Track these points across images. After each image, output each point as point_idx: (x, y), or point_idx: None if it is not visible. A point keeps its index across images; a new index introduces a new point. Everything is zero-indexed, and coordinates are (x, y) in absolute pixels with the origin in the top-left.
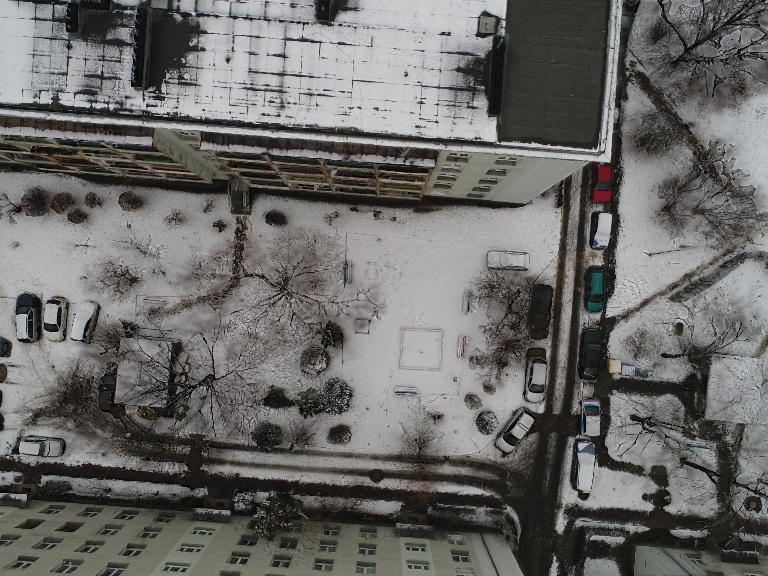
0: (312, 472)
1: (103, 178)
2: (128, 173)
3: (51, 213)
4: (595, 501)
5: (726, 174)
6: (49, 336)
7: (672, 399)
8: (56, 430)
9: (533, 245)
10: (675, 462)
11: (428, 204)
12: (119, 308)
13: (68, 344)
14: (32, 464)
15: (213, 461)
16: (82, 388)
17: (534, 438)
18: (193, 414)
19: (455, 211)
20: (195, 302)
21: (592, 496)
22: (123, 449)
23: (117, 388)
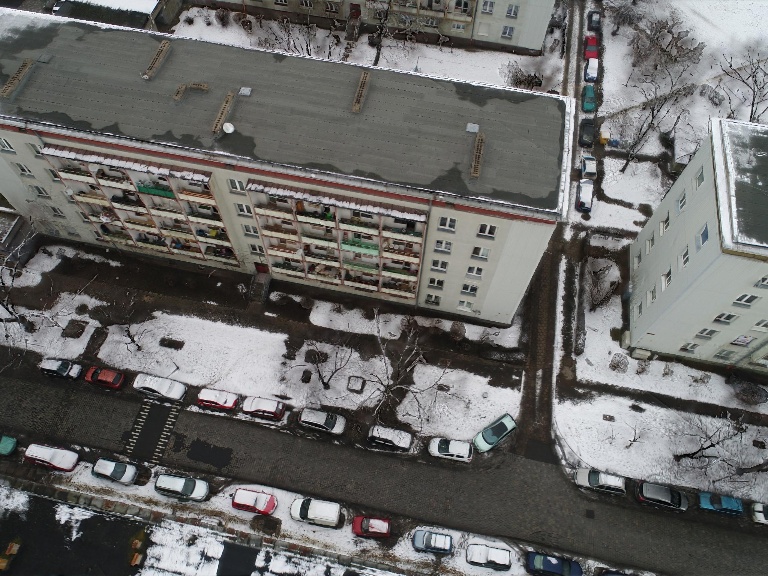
0: None
1: (267, 17)
2: None
3: (228, 28)
4: (595, 221)
5: (670, 31)
6: None
7: None
8: None
9: (545, 75)
10: (657, 202)
11: (475, 48)
12: None
13: None
14: None
15: None
16: None
17: None
18: None
19: (492, 53)
20: None
21: (593, 218)
22: None
23: None
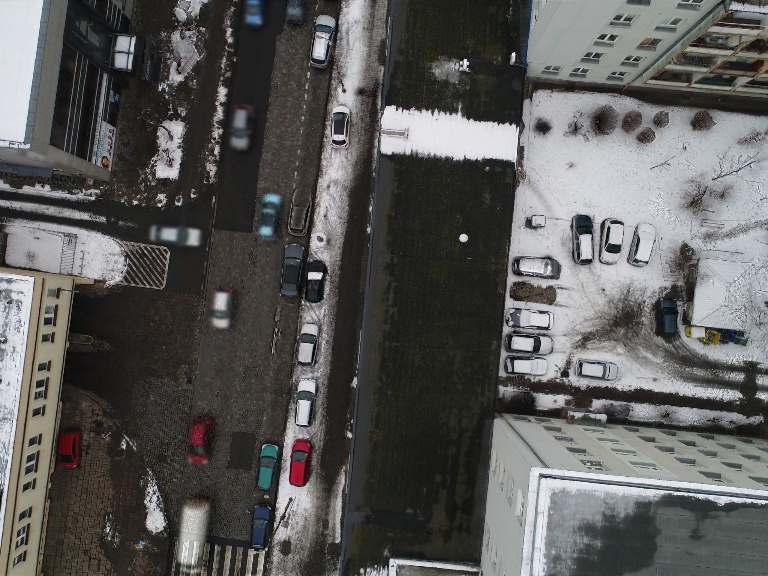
0: None
1: (659, 99)
2: (744, 86)
3: None
4: None
5: None
6: (608, 258)
7: None
8: (606, 354)
9: None
10: None
11: None
12: (674, 231)
13: (619, 267)
14: (583, 388)
15: (767, 389)
16: (633, 312)
17: None
18: (749, 340)
19: None
20: (752, 226)
21: None
22: (675, 375)
23: (696, 309)
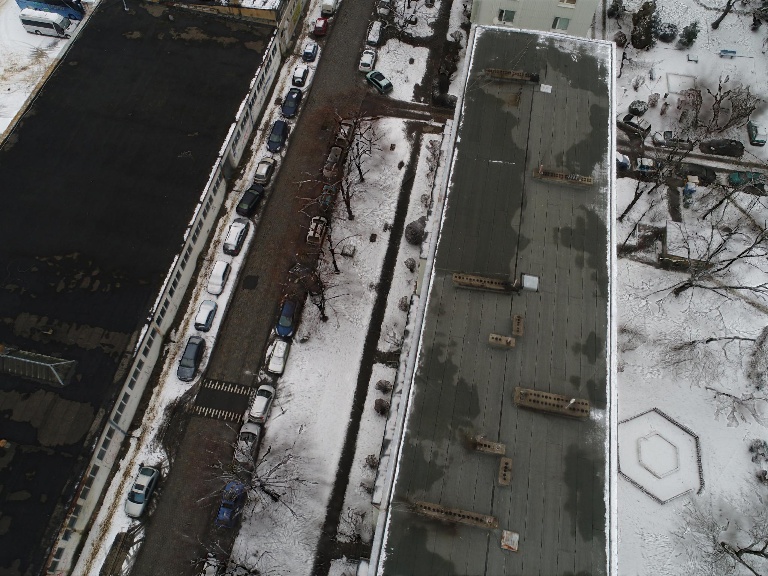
0: (592, 30)
1: None
2: None
3: None
4: None
5: None
6: None
7: (669, 219)
8: None
9: None
10: (618, 216)
11: None
12: None
13: None
14: None
15: None
16: None
17: (625, 138)
18: None
19: None
20: None
21: None
22: None
23: None
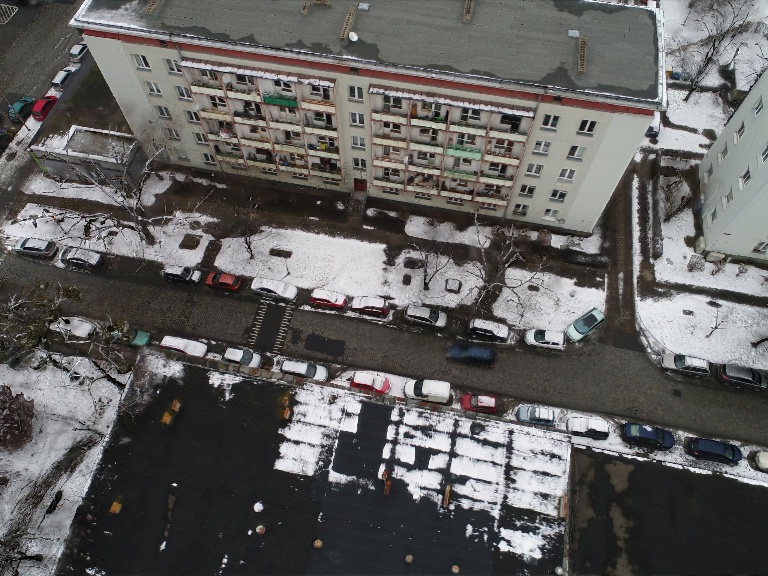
0: None
1: None
2: None
3: None
4: (663, 145)
5: None
6: None
7: None
8: None
9: None
10: (720, 127)
11: None
12: None
13: None
14: None
15: None
16: None
17: None
18: None
19: None
20: None
21: (660, 142)
22: None
23: None
